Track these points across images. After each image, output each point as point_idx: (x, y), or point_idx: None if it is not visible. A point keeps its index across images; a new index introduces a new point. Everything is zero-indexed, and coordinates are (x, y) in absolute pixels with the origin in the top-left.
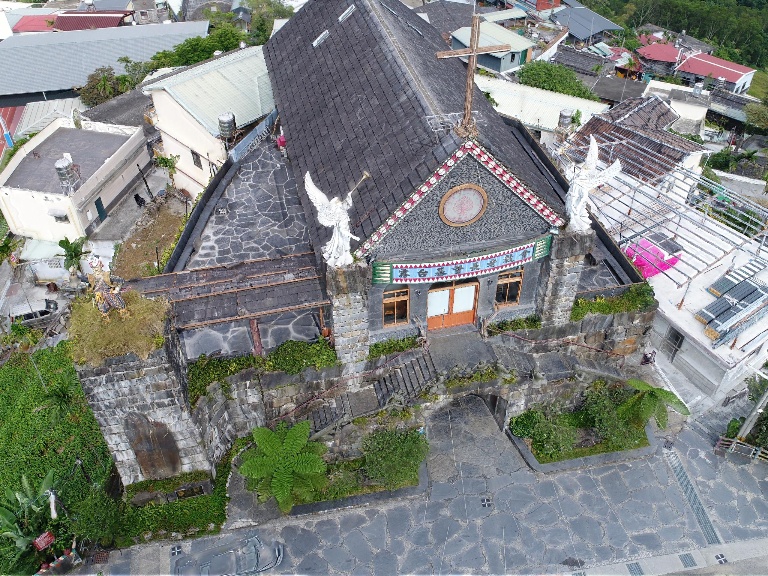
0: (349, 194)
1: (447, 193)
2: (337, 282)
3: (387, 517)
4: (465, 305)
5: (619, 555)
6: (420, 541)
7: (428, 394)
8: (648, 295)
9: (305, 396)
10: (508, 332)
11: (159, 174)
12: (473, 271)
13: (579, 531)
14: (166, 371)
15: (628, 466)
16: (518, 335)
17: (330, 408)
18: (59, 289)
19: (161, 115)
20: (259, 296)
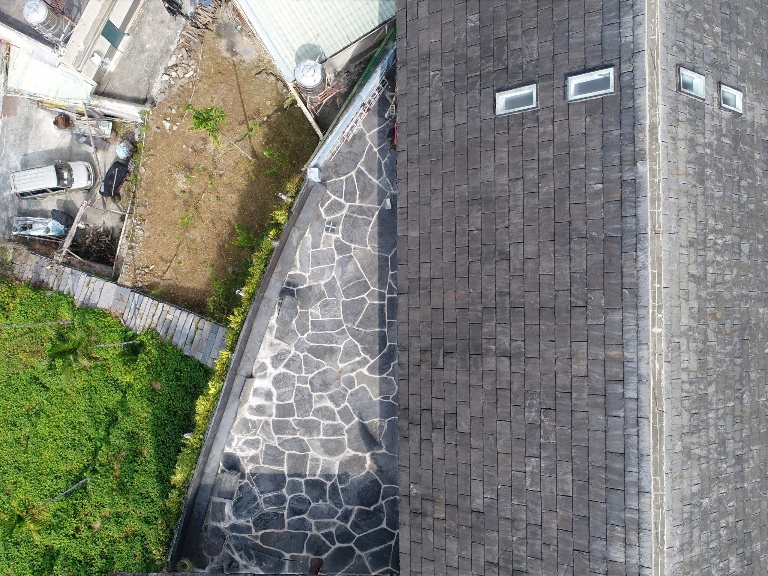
0: None
1: None
2: None
3: None
4: None
5: None
6: None
7: None
8: None
9: None
10: None
11: None
12: None
13: None
14: None
15: None
16: None
17: None
18: (72, 122)
19: None
20: None
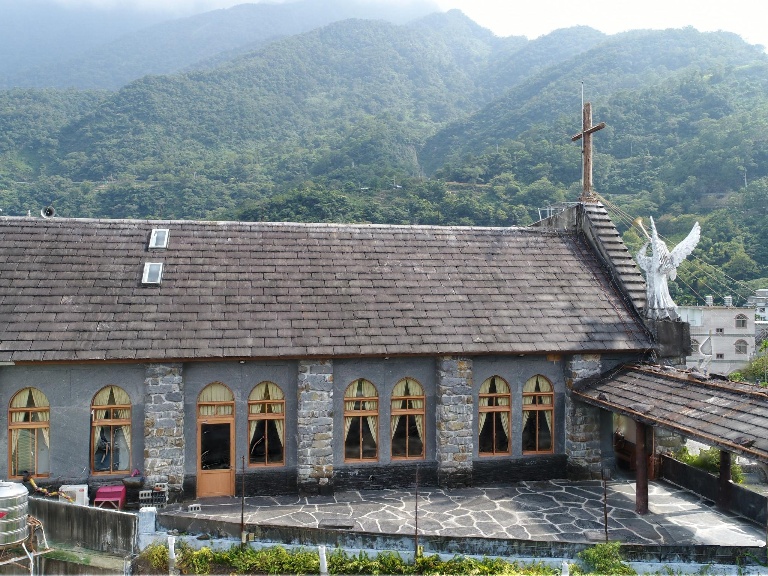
0: None
1: None
2: None
3: None
4: None
5: None
6: None
7: None
8: None
9: None
10: None
11: None
12: None
13: None
14: None
15: None
16: None
17: None
18: None
19: None
20: None
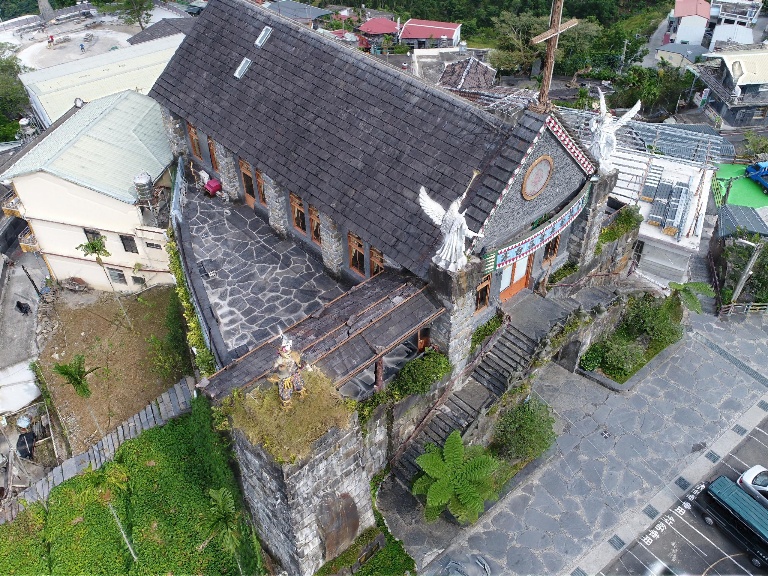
0: (464, 196)
1: (529, 170)
2: (459, 285)
3: (543, 486)
4: (520, 273)
5: (722, 425)
6: (583, 491)
7: (538, 361)
8: (638, 213)
9: (423, 413)
10: (557, 284)
11: (21, 273)
12: (551, 235)
13: (684, 422)
14: (356, 434)
15: (677, 357)
16: (564, 283)
17: (446, 414)
18: None
19: (29, 202)
20: (382, 329)
